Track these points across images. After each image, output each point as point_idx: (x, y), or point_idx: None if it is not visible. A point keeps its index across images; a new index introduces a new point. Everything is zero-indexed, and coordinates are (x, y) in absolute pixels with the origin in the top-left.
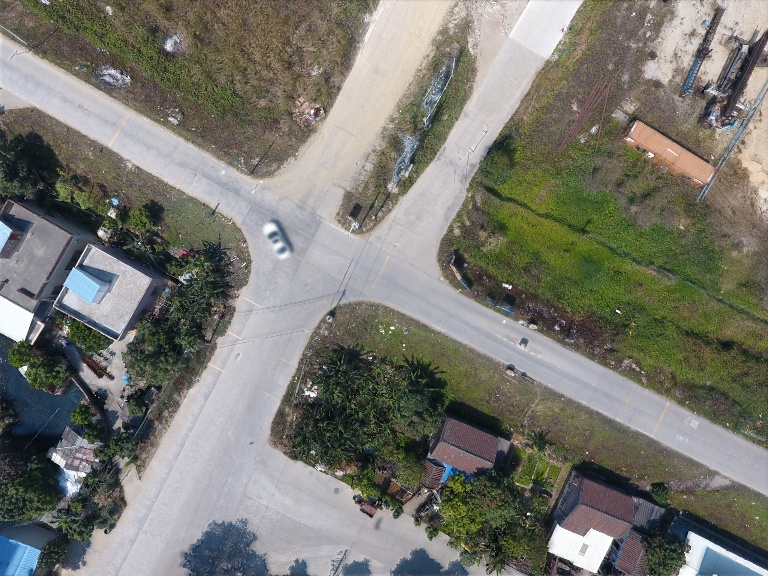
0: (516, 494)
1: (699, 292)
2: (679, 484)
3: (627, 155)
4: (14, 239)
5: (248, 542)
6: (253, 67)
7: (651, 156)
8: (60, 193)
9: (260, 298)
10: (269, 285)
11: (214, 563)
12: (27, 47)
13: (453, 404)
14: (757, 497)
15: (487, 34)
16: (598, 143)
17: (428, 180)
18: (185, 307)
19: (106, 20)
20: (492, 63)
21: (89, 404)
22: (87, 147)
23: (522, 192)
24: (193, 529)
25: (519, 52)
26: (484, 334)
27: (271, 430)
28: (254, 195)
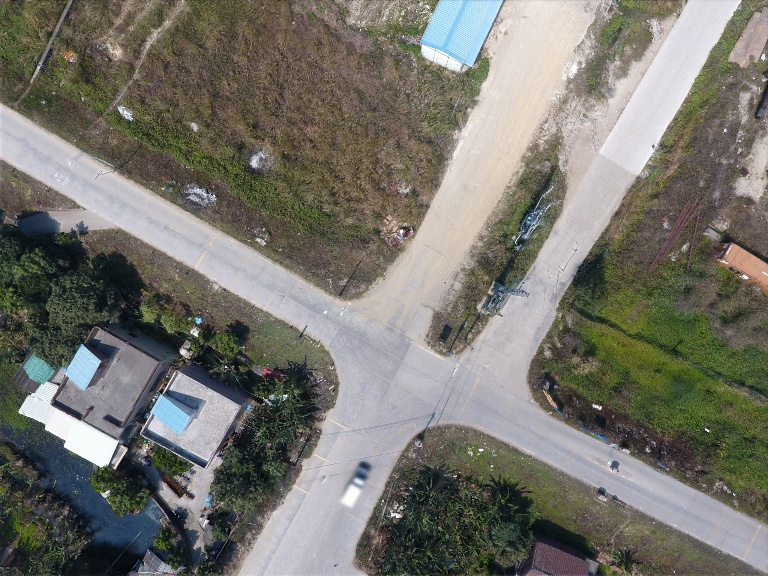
0: None
1: None
2: None
3: (718, 274)
4: (101, 367)
5: None
6: (341, 186)
7: (745, 278)
8: (146, 316)
9: (347, 420)
10: (357, 407)
11: None
12: (112, 167)
13: (539, 522)
14: None
15: (577, 150)
16: (689, 262)
17: (518, 300)
18: (273, 432)
19: (191, 137)
20: (582, 180)
21: (169, 523)
22: (173, 269)
23: (613, 313)
24: None
25: (609, 168)
26: (575, 457)
27: (356, 552)
28: (342, 317)
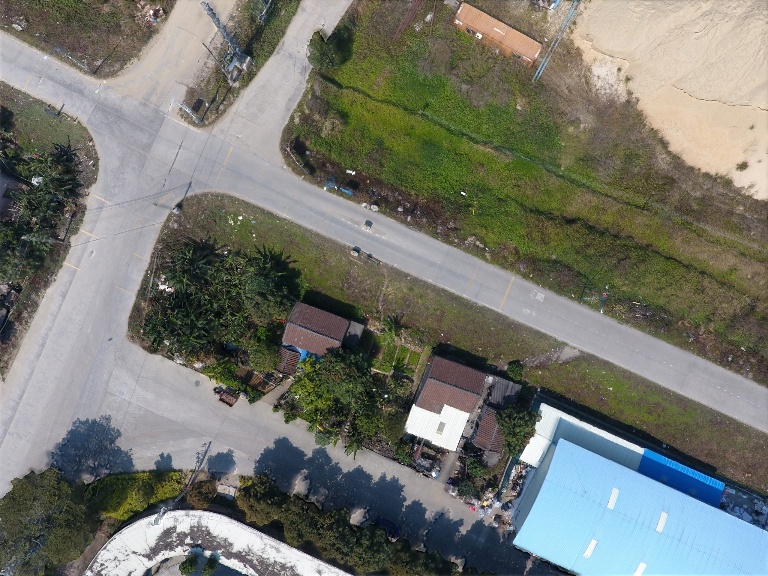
0: (366, 372)
1: (537, 167)
2: (533, 360)
3: (461, 40)
4: None
5: (113, 438)
6: None
7: (480, 37)
8: None
9: (109, 195)
10: (117, 181)
11: (81, 461)
12: None
13: (309, 294)
14: (606, 366)
15: None
16: (432, 30)
17: (268, 73)
18: (34, 205)
19: None
20: None
21: None
22: None
23: (359, 80)
24: (58, 428)
25: None
26: (329, 218)
27: (128, 325)
28: (98, 94)
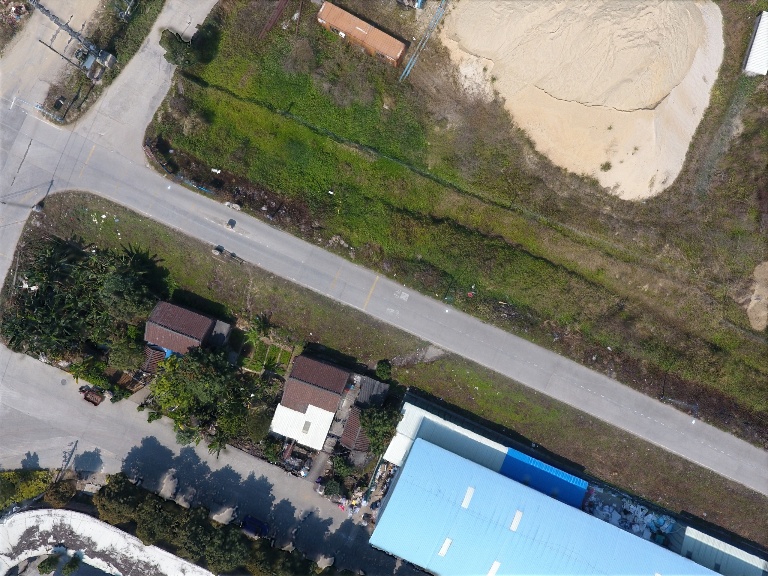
0: (227, 371)
1: (401, 167)
2: (401, 359)
3: (328, 39)
4: None
5: None
6: None
7: (343, 36)
8: None
9: None
10: None
11: None
12: None
13: (178, 293)
14: (470, 365)
15: None
16: (298, 28)
17: (133, 71)
18: None
19: None
20: None
21: None
22: None
23: (223, 78)
24: None
25: None
26: (192, 217)
27: None
28: None
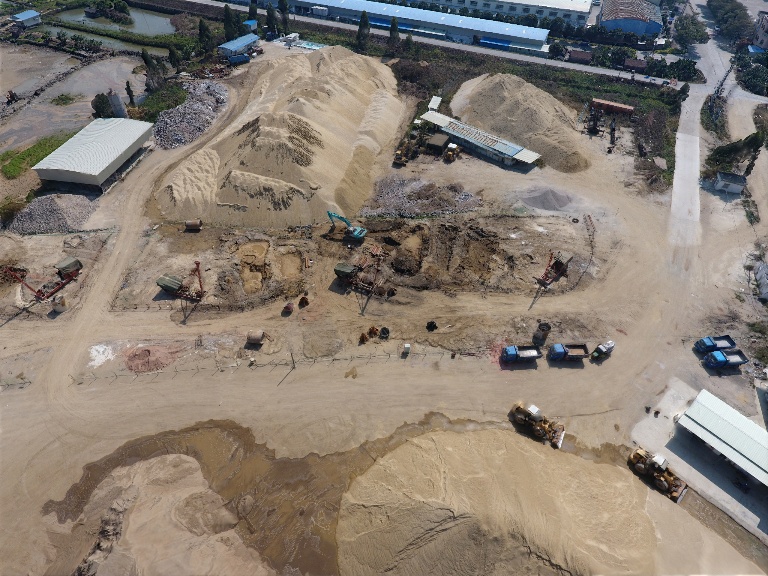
0: None
1: None
2: None
3: None
4: None
5: None
6: None
7: None
8: None
9: None
10: None
11: None
12: None
13: None
14: None
15: None
16: None
17: None
18: None
19: None
20: None
21: None
22: None
23: None
24: None
25: None
26: None
27: None
28: None
